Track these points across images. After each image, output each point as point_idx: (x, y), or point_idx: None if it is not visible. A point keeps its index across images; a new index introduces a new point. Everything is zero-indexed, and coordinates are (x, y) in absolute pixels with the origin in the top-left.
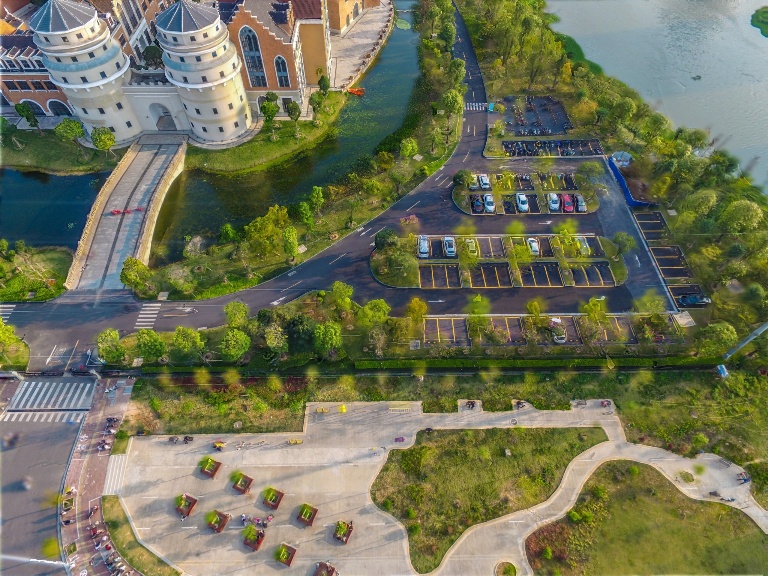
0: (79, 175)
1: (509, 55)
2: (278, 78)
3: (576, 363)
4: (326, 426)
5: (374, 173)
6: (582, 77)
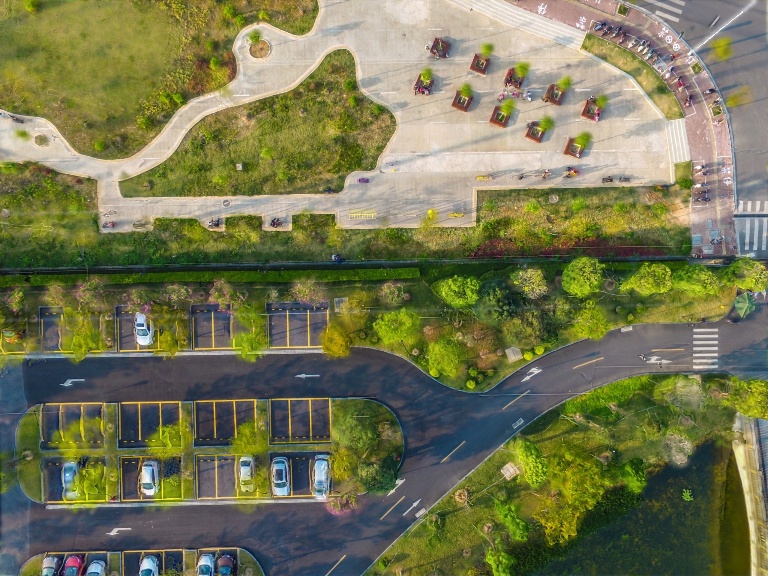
0: None
1: None
2: None
3: (132, 277)
4: (450, 197)
5: None
6: None
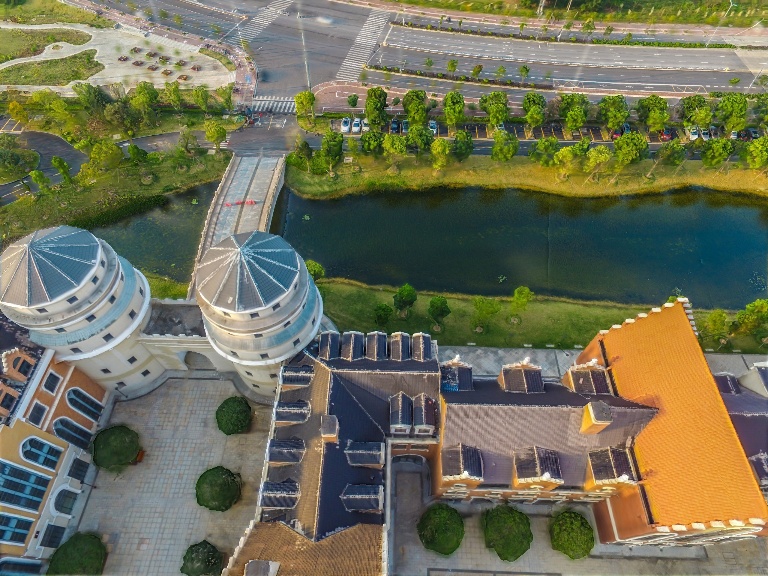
0: None
1: None
2: None
3: None
4: None
5: None
6: None
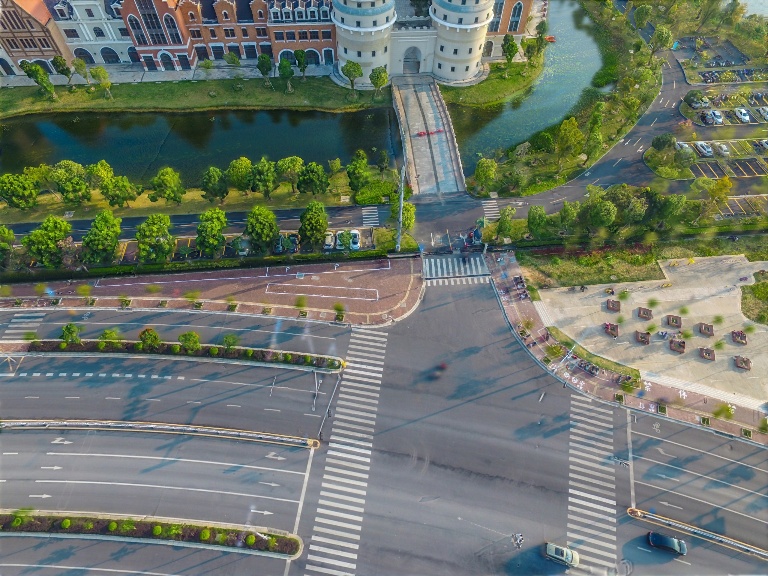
0: (353, 112)
1: (674, 3)
2: (510, 23)
3: None
4: (682, 274)
5: (603, 100)
6: (747, 18)
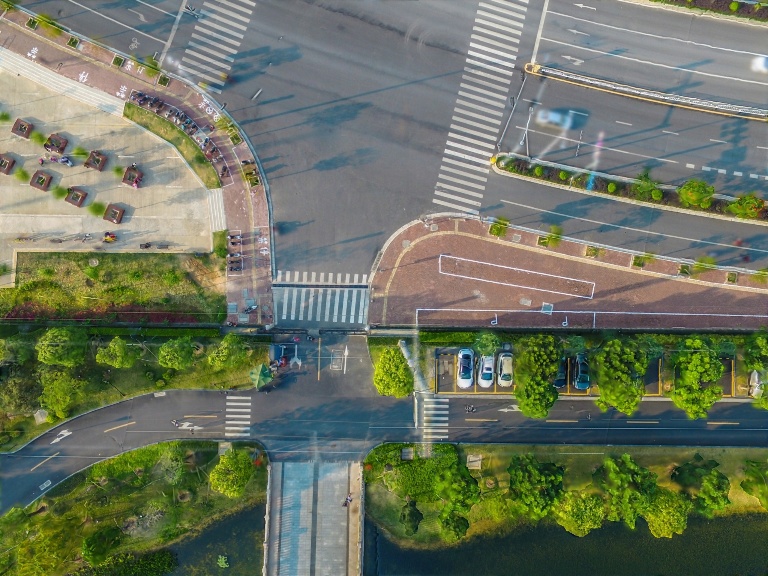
0: None
1: None
2: None
3: None
4: None
5: None
6: None
